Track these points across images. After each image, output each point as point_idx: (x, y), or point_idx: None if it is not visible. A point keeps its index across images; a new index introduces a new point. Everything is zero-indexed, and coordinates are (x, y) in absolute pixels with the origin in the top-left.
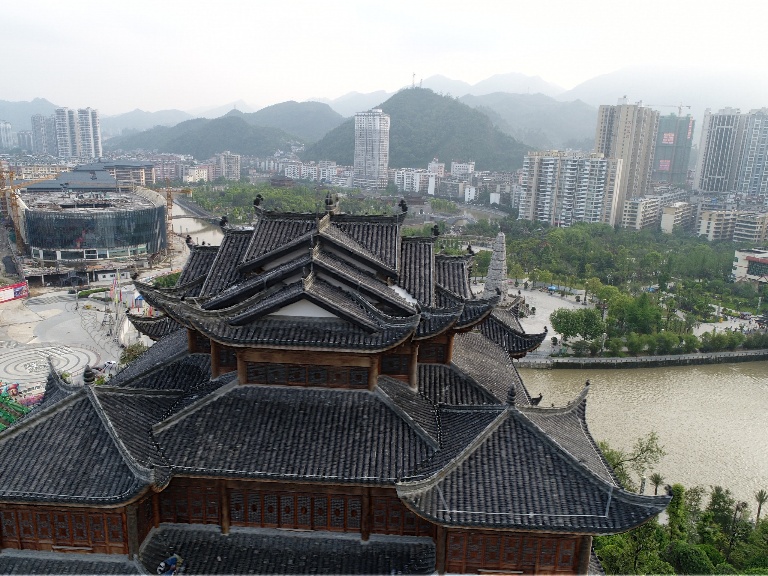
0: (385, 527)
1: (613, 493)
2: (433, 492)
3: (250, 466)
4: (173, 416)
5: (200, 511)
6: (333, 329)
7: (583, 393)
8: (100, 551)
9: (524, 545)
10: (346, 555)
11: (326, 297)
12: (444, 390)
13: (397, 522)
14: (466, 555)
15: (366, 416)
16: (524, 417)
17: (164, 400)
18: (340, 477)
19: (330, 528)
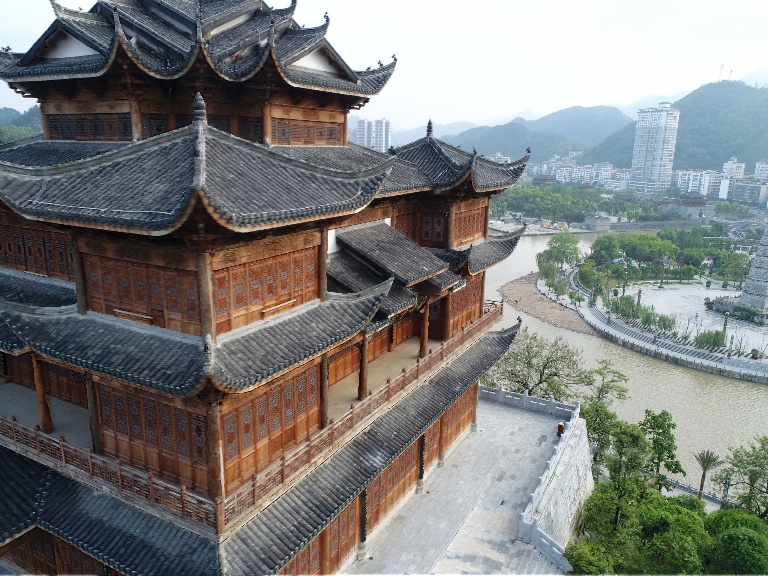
0: None
1: None
2: (35, 184)
3: None
4: None
5: None
6: (87, 62)
7: (382, 163)
8: None
9: (150, 280)
10: (52, 297)
11: (82, 27)
12: None
13: None
14: (103, 289)
15: None
16: None
17: None
18: None
19: (59, 275)
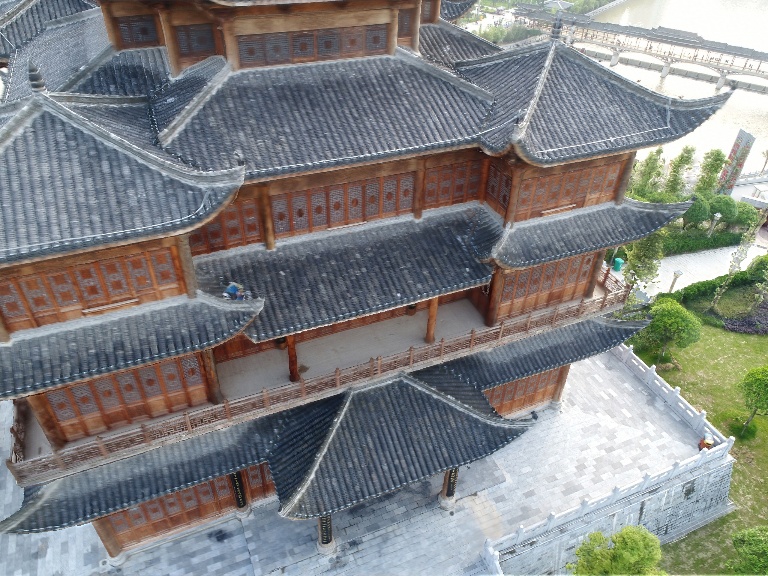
0: (436, 200)
1: (671, 105)
2: (528, 136)
3: (311, 156)
4: (177, 119)
5: (237, 232)
6: None
7: None
8: (148, 300)
9: (581, 178)
10: (408, 236)
11: None
12: (446, 50)
13: (447, 192)
14: (533, 201)
15: (403, 82)
16: (572, 50)
17: (133, 109)
18: (416, 147)
19: (382, 215)
